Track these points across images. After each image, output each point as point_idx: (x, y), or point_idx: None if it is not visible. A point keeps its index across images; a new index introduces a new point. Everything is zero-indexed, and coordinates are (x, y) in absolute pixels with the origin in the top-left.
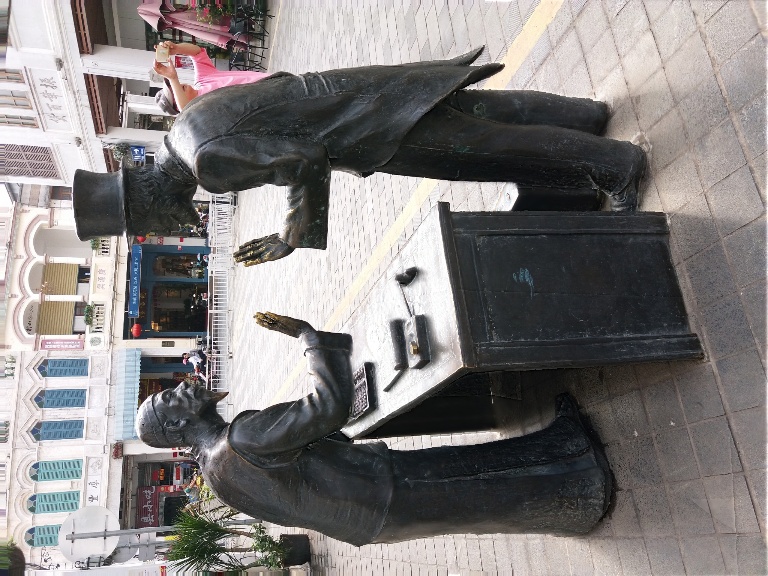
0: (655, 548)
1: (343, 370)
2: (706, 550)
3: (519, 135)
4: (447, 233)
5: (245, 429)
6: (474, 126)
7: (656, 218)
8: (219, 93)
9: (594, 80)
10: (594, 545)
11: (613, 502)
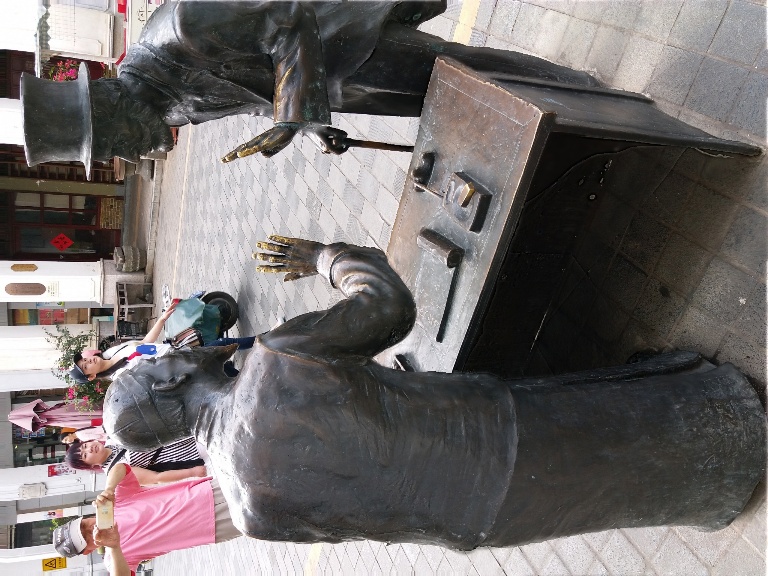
0: None
1: (387, 270)
2: None
3: None
4: (459, 66)
5: (282, 330)
6: None
7: (635, 93)
8: None
9: None
10: None
11: None
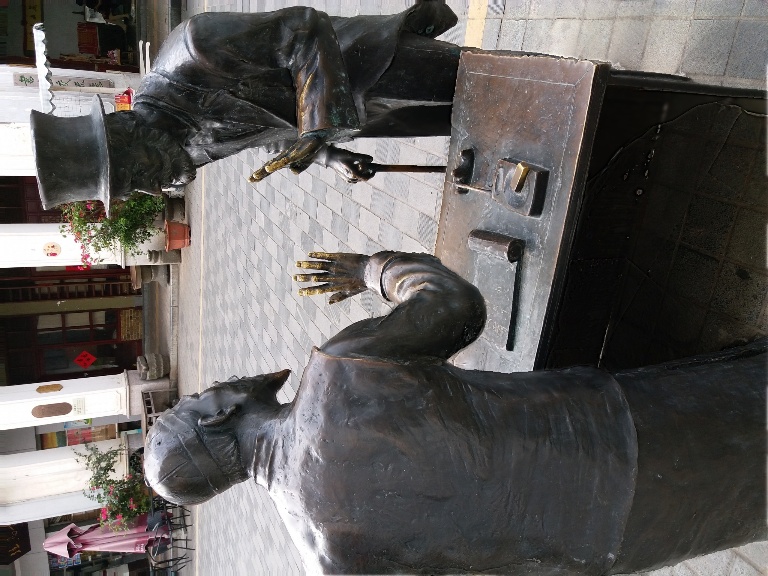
0: None
1: (444, 270)
2: None
3: None
4: None
5: (340, 336)
6: None
7: None
8: None
9: None
10: None
11: None
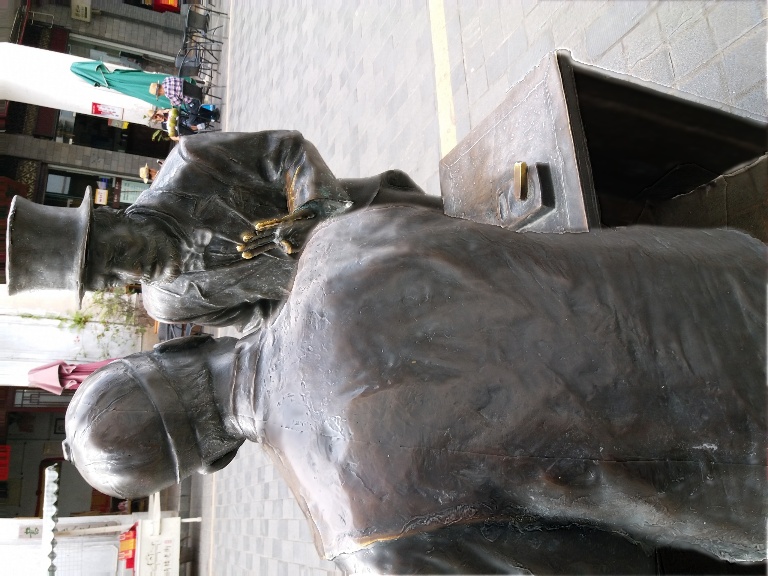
0: None
1: None
2: None
3: None
4: None
5: None
6: None
7: None
8: None
9: None
10: None
11: None
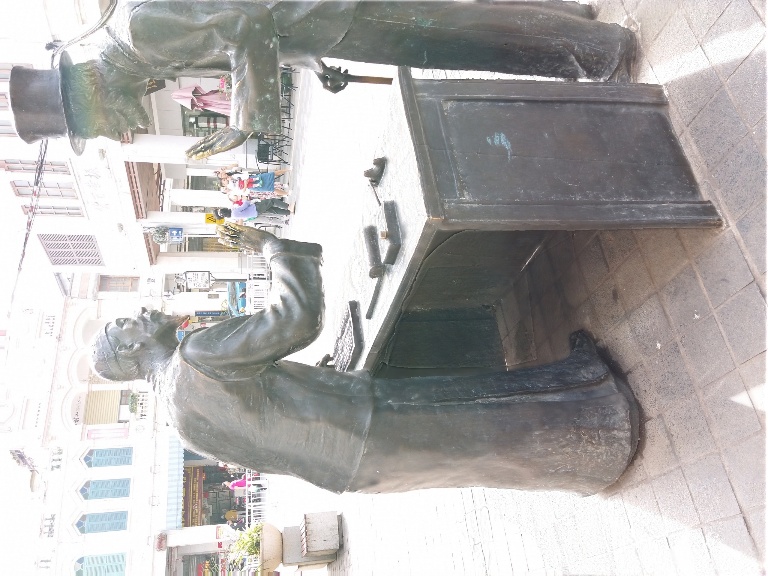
0: (695, 474)
1: (311, 278)
2: (754, 454)
3: (488, 10)
4: (408, 93)
5: (199, 339)
6: (437, 1)
7: (651, 89)
8: None
9: None
10: (627, 497)
11: (643, 437)
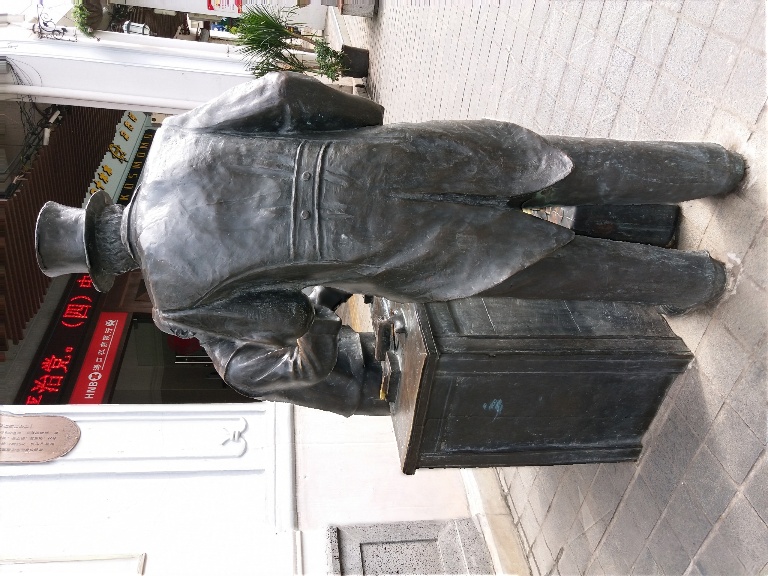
0: None
1: (328, 349)
2: (568, 509)
3: (560, 287)
4: (425, 383)
5: (239, 373)
6: None
7: (678, 362)
8: (186, 211)
9: (764, 118)
10: None
11: None
